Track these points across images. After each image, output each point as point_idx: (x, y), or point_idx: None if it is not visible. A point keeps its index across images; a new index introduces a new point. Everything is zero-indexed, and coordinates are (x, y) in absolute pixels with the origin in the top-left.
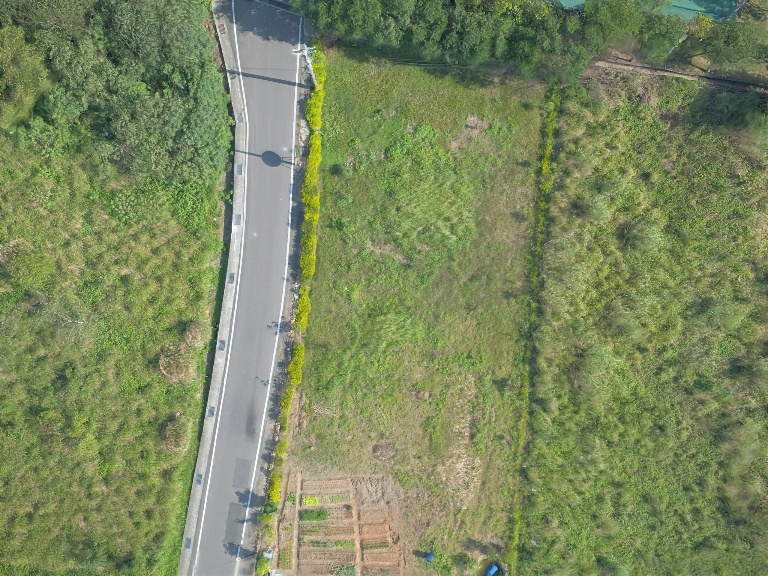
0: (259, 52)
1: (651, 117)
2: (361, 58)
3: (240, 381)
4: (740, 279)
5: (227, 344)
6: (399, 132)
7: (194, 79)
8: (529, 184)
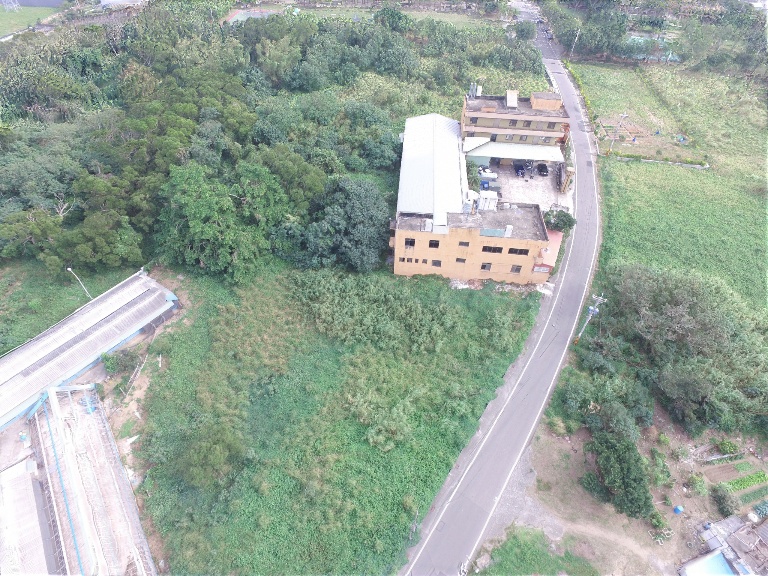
0: (547, 60)
1: None
2: None
3: None
4: None
5: None
6: None
7: (538, 51)
8: None
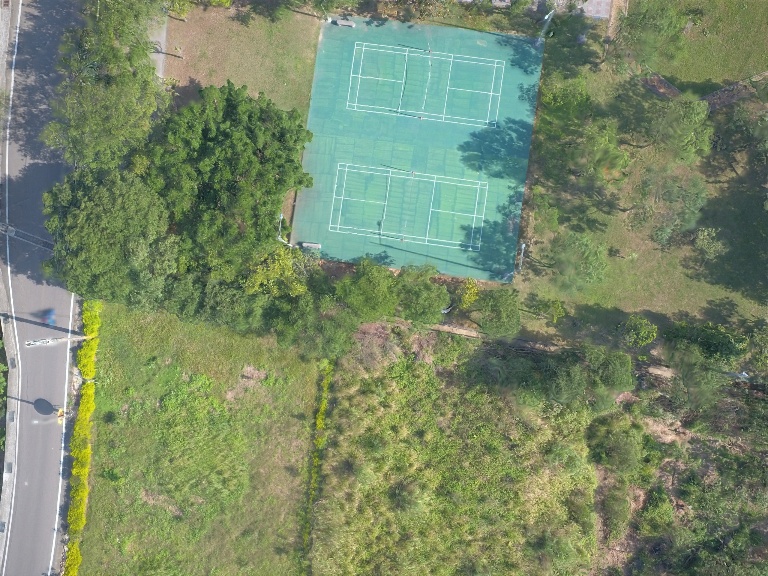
0: (33, 297)
1: (427, 374)
2: None
3: None
4: (512, 543)
5: None
6: (174, 380)
7: None
8: (304, 437)
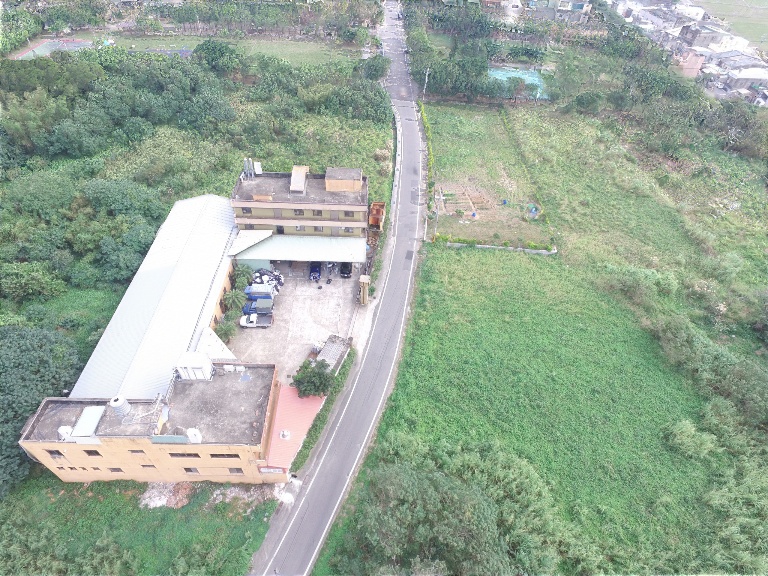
0: (400, 102)
1: None
2: (434, 106)
3: (408, 162)
4: None
5: None
6: None
7: (384, 93)
8: None
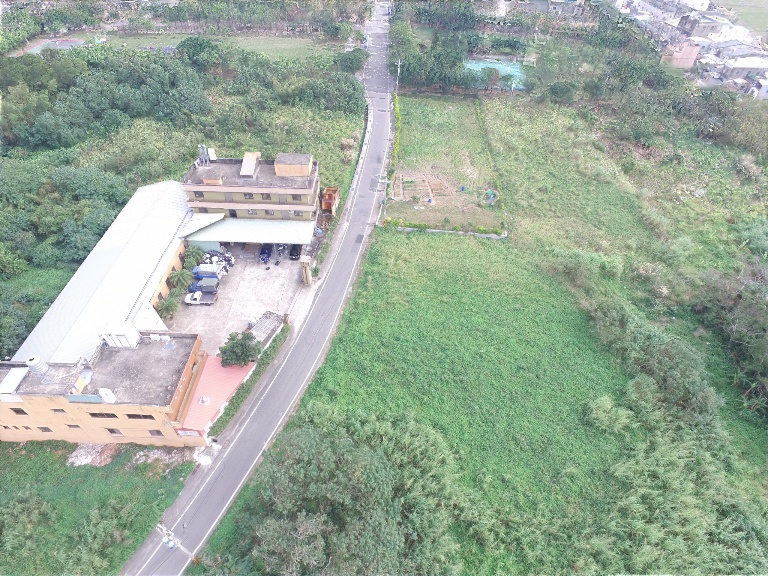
0: (375, 94)
1: None
2: (410, 97)
3: (374, 151)
4: None
5: (367, 144)
6: None
7: (357, 85)
8: None
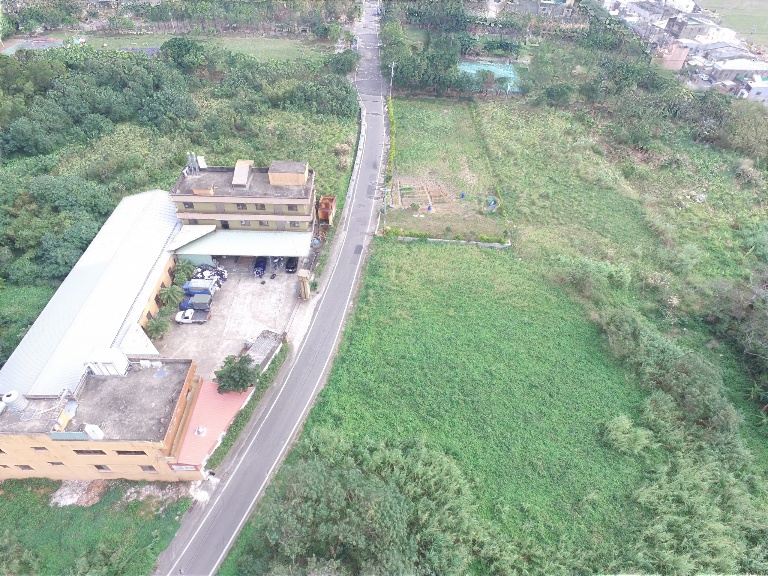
0: (368, 97)
1: None
2: (403, 100)
3: None
4: None
5: (362, 149)
6: None
7: (350, 88)
8: None
